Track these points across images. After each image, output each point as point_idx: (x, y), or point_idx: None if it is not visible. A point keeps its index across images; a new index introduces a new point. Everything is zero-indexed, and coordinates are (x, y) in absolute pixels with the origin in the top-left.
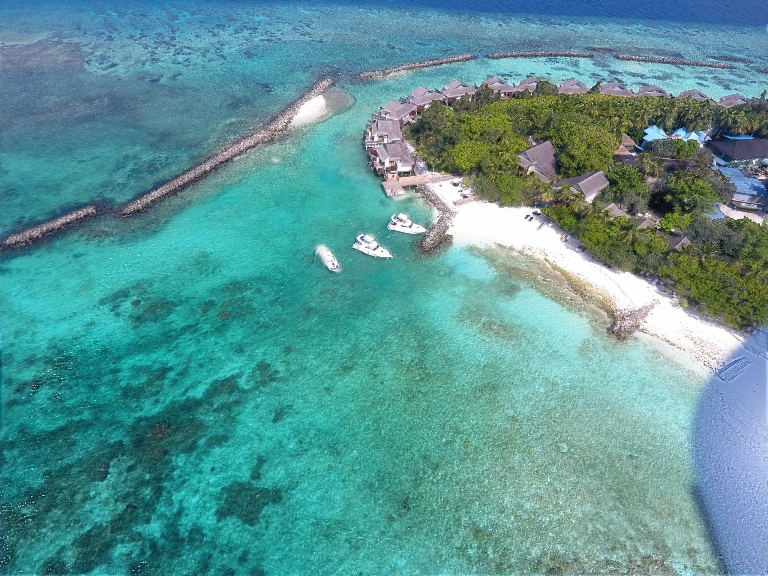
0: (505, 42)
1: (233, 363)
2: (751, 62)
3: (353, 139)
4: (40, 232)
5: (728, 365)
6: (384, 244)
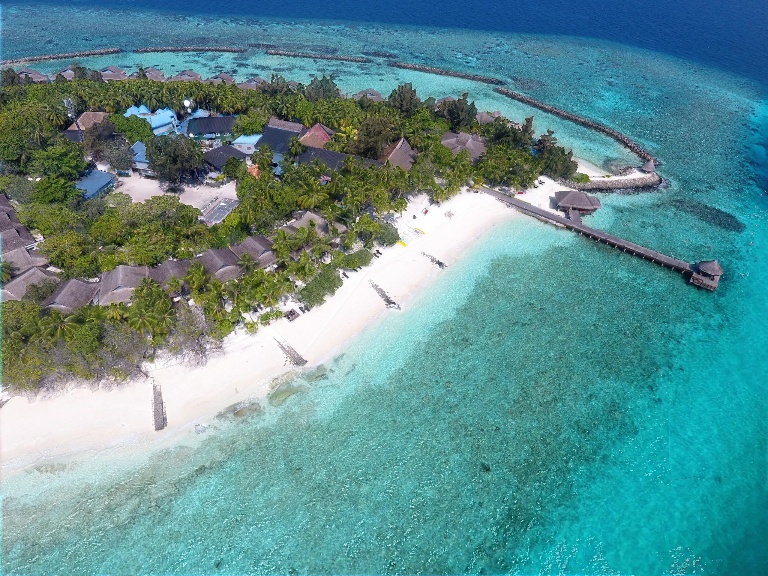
0: (176, 39)
1: None
2: (394, 57)
3: None
4: None
5: None
6: None
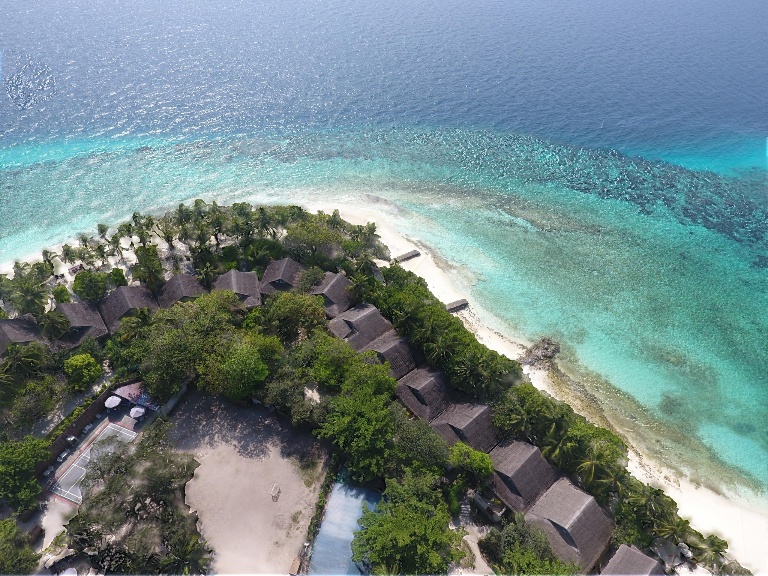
0: None
1: None
2: None
3: None
4: None
5: (456, 310)
6: None
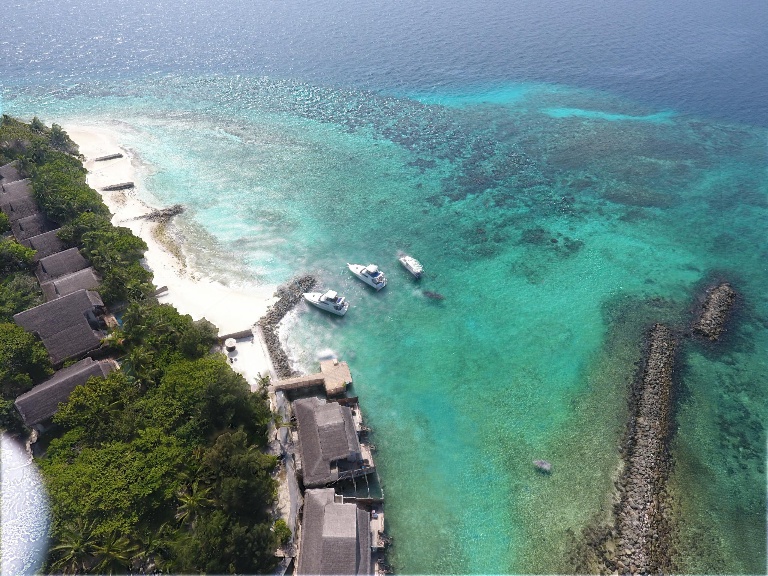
0: None
1: (458, 207)
2: None
3: (414, 574)
4: (714, 299)
5: (119, 189)
6: (353, 292)
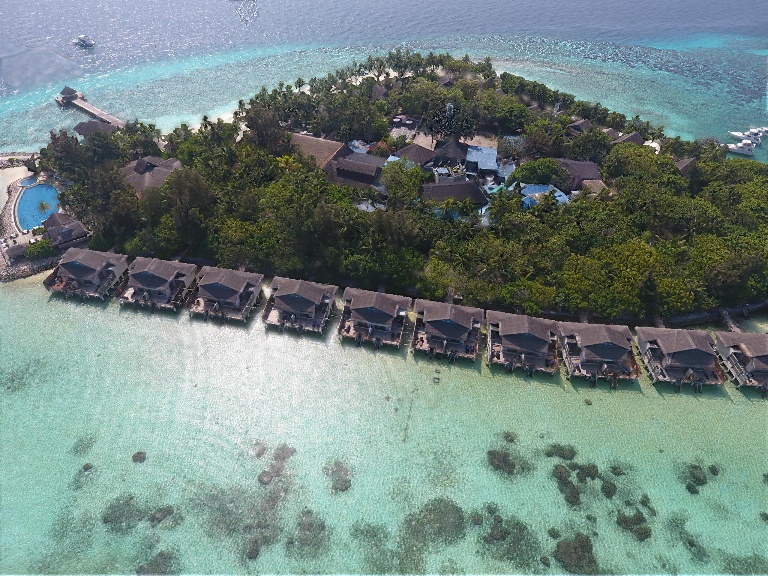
0: None
1: (754, 106)
2: None
3: None
4: None
5: None
6: None
